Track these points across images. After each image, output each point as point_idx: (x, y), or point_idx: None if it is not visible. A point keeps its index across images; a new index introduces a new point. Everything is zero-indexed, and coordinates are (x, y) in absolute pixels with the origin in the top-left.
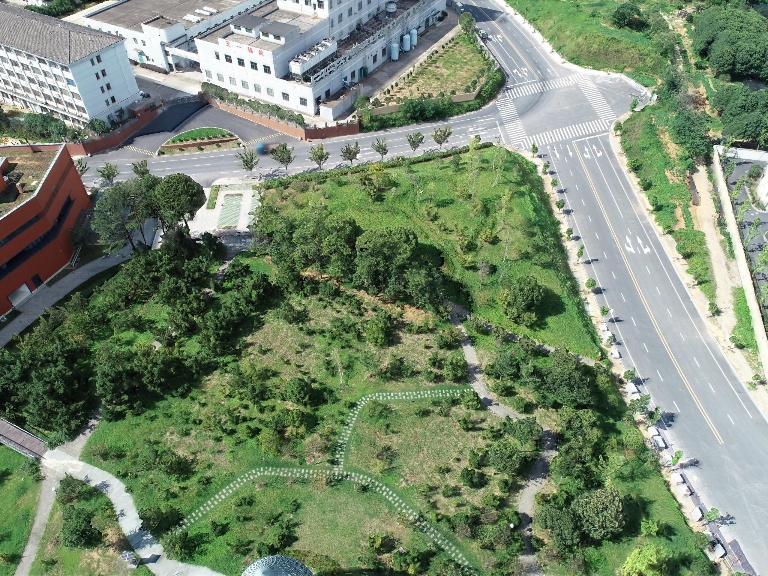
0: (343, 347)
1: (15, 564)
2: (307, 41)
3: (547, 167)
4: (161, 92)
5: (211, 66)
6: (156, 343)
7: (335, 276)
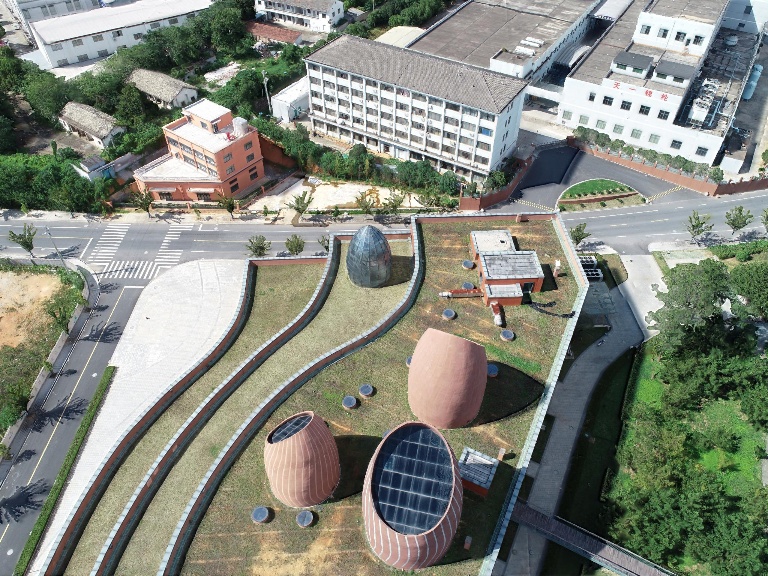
0: None
1: None
2: None
3: None
4: None
5: (576, 107)
6: (767, 469)
7: None
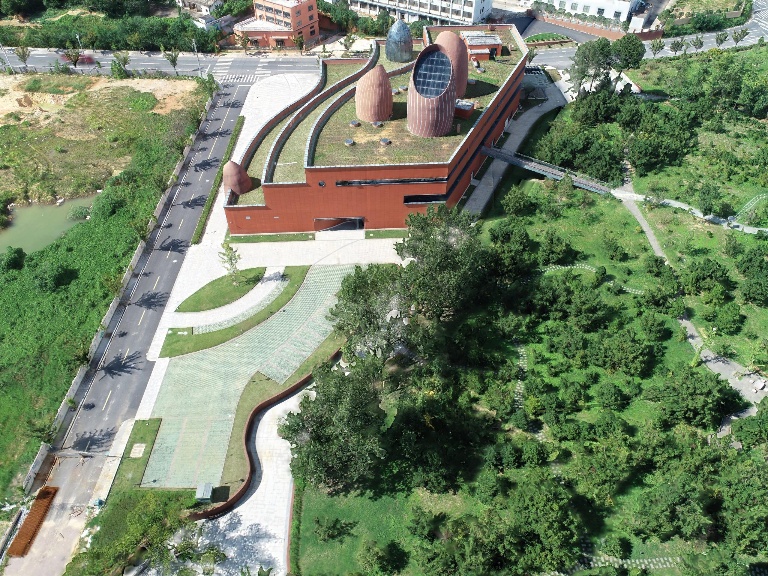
0: (767, 143)
1: (644, 234)
2: None
3: None
4: (492, 11)
5: None
6: None
7: (744, 103)
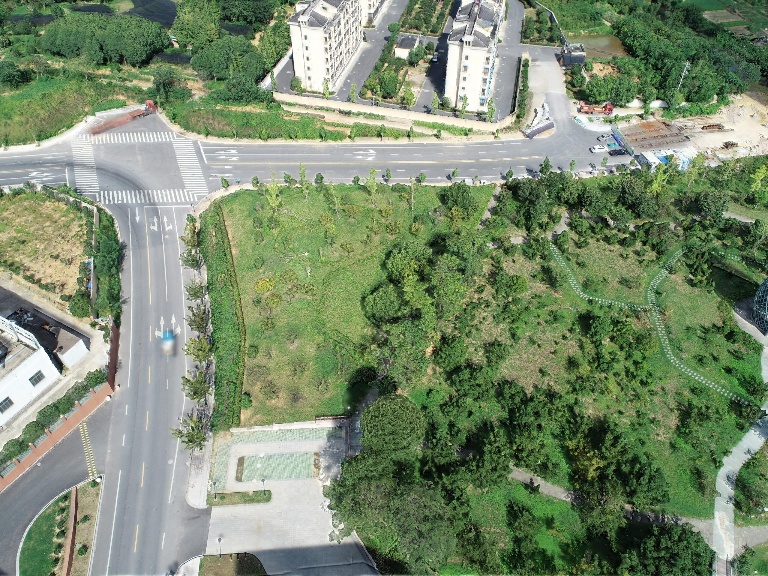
0: None
1: None
2: None
3: (257, 179)
4: None
5: None
6: (546, 490)
7: None
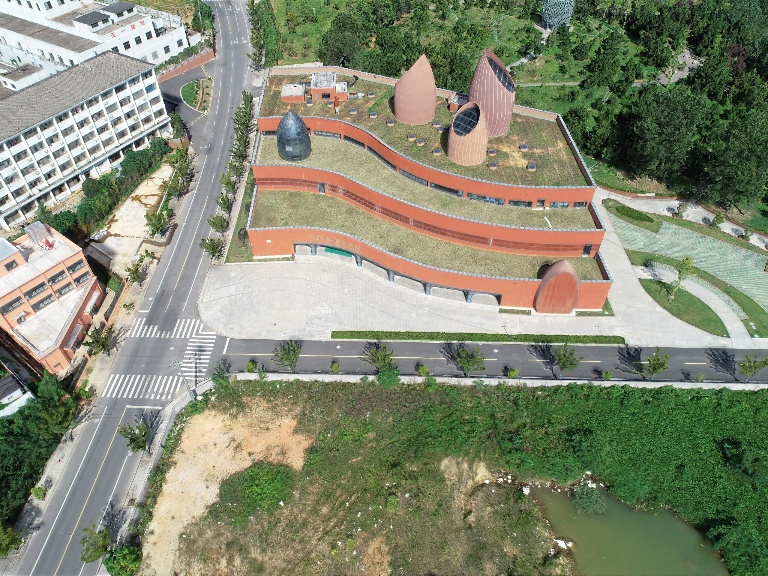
0: None
1: None
2: None
3: None
4: None
5: None
6: None
7: None
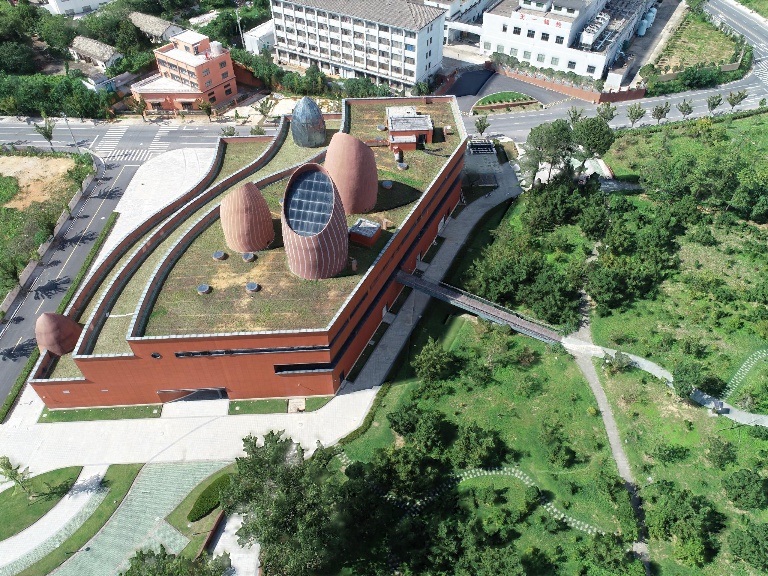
0: (767, 263)
1: (600, 416)
2: (585, 15)
3: None
4: (445, 62)
5: (493, 38)
6: None
7: (739, 206)
